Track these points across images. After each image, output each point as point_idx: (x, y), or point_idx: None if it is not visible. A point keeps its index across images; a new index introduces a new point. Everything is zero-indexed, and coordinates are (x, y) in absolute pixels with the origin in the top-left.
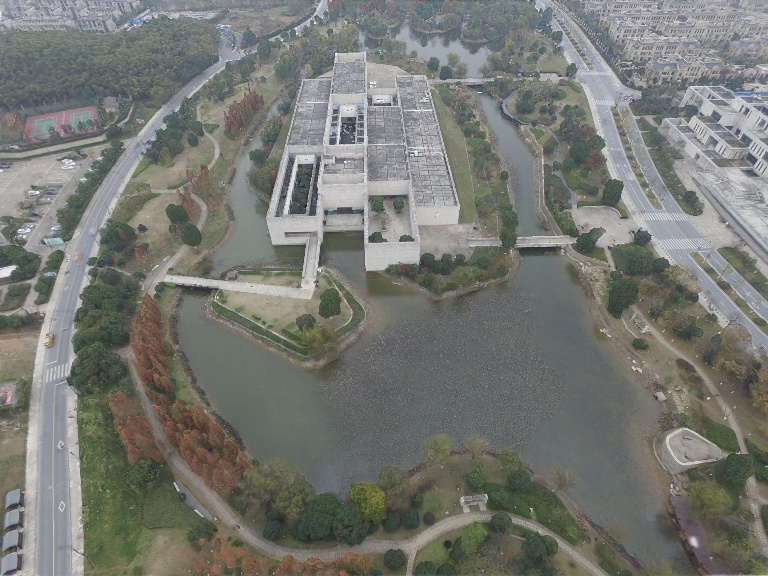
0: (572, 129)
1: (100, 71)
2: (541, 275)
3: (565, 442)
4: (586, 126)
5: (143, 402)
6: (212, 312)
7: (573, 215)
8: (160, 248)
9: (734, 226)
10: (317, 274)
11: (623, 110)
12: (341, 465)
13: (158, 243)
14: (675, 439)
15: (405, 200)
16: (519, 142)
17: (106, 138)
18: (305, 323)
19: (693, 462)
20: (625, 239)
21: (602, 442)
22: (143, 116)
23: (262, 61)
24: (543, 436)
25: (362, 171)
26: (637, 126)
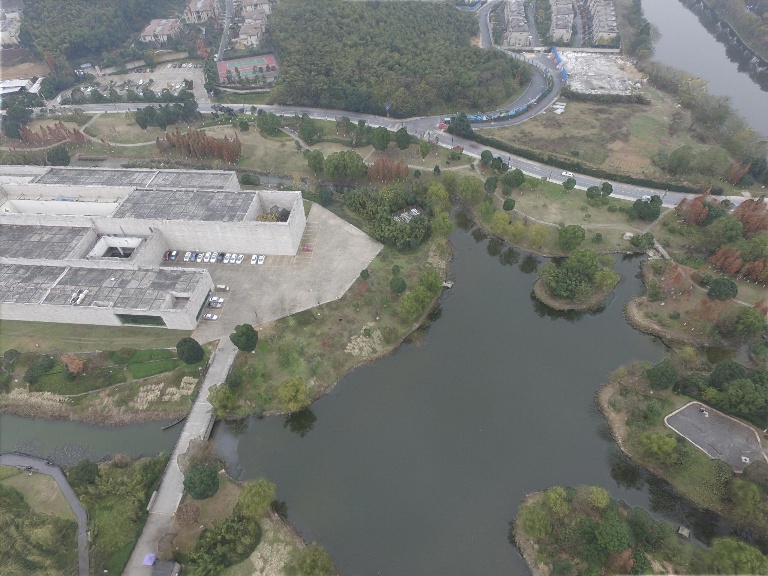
0: None
1: None
2: None
3: None
4: None
5: None
6: None
7: None
8: (4, 137)
9: None
10: None
11: None
12: None
13: None
14: None
15: None
16: None
17: None
18: None
19: None
20: None
21: None
22: (252, 99)
23: None
24: None
25: None
26: None
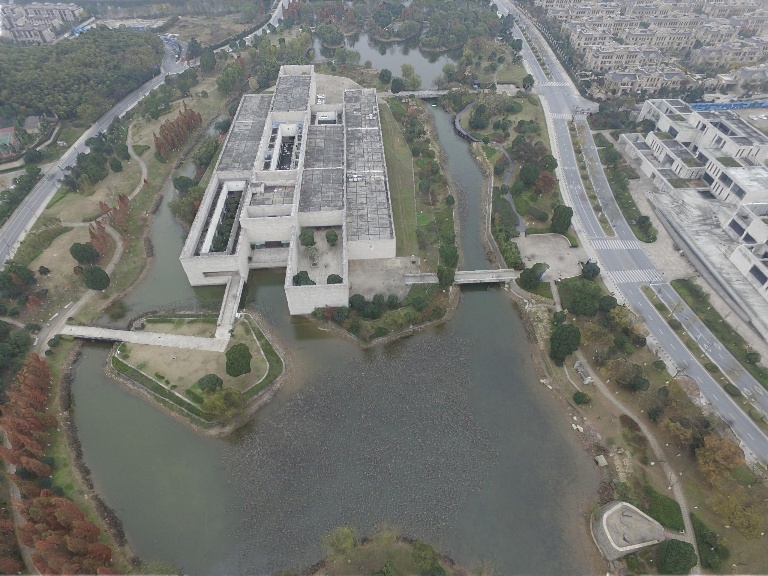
0: (524, 147)
1: (22, 88)
2: (481, 315)
3: (493, 522)
4: (539, 143)
5: (12, 488)
6: (112, 369)
7: (520, 244)
8: (63, 293)
9: (688, 255)
10: (235, 321)
11: (580, 124)
12: (235, 561)
13: (62, 287)
14: (613, 516)
15: (341, 230)
16: (470, 161)
17: (23, 163)
18: (207, 386)
19: (632, 546)
20: (573, 271)
21: (534, 520)
22: (69, 137)
23: (206, 74)
24: (469, 515)
25: (292, 200)
26: (594, 142)
